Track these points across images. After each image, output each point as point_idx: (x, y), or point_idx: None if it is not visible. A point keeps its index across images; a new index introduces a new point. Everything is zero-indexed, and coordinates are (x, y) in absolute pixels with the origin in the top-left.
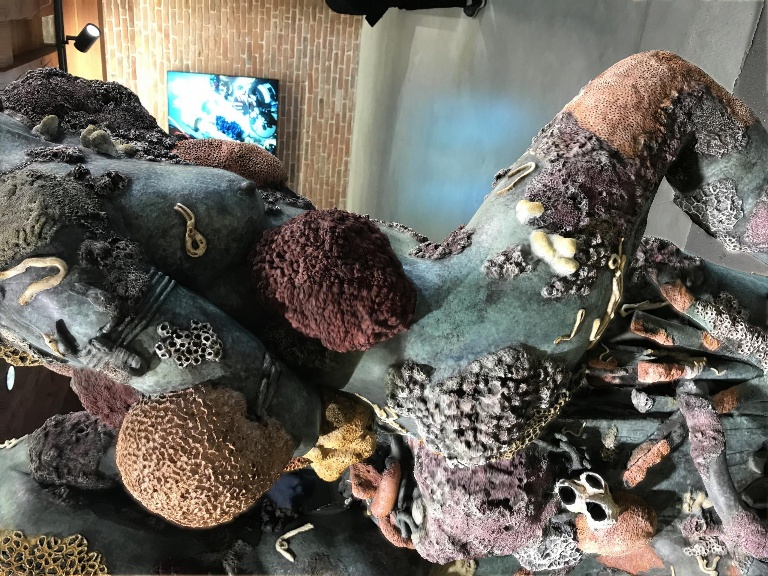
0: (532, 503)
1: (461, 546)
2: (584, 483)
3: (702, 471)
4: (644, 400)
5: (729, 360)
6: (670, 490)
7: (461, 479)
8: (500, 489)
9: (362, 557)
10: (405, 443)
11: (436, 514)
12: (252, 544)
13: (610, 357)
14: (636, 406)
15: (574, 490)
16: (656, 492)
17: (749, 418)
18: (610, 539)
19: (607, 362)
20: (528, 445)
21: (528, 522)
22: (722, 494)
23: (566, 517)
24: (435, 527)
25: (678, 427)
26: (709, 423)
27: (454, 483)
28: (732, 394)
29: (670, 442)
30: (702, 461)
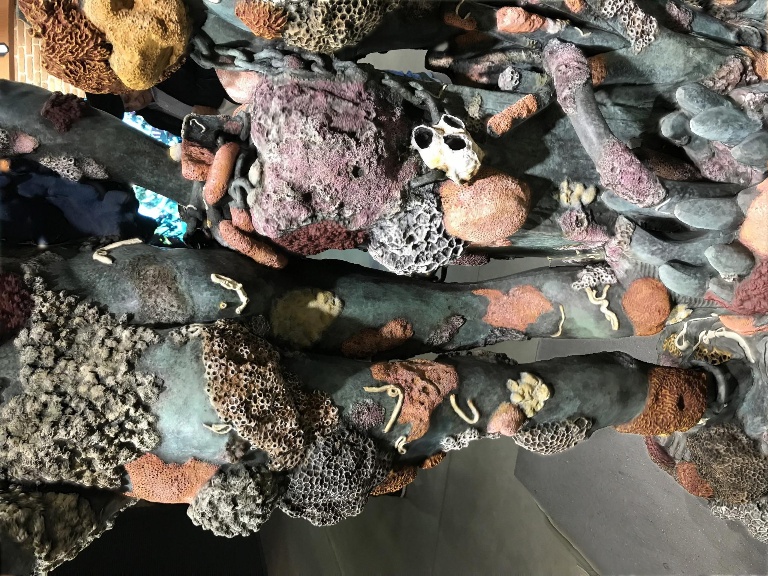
0: (382, 138)
1: (303, 196)
2: (442, 125)
3: (568, 104)
4: (509, 73)
5: (594, 28)
6: (545, 178)
7: (298, 105)
8: (344, 118)
9: (196, 255)
10: (251, 144)
11: (272, 158)
12: (63, 256)
13: (468, 13)
14: (503, 88)
15: (430, 129)
16: (529, 177)
17: (623, 108)
18: (477, 200)
19: (465, 20)
20: (378, 85)
21: (380, 168)
22: (591, 122)
23: (427, 177)
24: (272, 177)
25: (544, 85)
26: (573, 57)
27: (290, 111)
28: (600, 60)
29: (536, 97)
30: (567, 92)
